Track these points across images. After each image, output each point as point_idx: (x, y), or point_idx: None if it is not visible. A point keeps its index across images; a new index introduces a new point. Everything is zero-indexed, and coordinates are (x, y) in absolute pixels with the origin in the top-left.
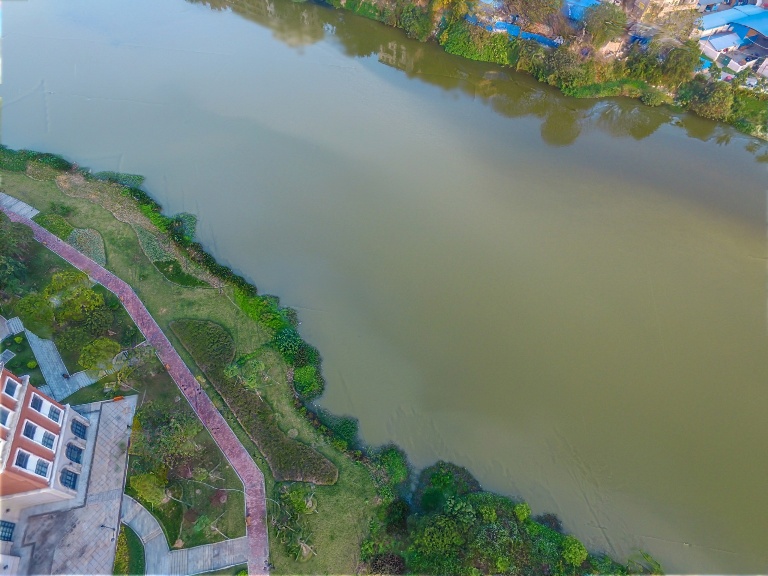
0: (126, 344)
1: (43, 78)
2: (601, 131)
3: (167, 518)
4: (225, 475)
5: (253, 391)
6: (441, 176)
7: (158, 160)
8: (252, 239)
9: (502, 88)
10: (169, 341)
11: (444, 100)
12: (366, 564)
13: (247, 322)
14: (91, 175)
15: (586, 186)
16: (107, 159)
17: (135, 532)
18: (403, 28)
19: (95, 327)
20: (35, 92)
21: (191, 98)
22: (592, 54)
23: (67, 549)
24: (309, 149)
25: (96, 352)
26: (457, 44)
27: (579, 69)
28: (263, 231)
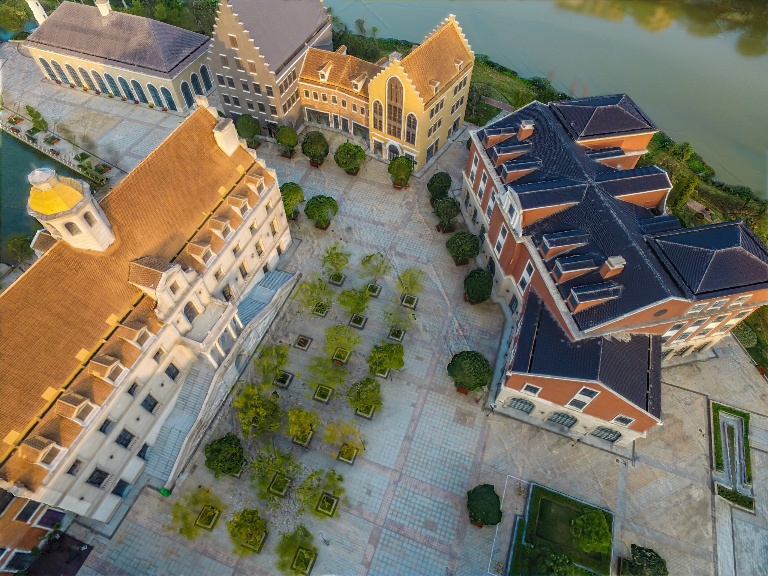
0: None
1: None
2: None
3: None
4: None
5: None
6: (716, 56)
7: (490, 45)
8: (600, 92)
9: None
10: None
11: (685, 9)
12: None
13: None
14: None
15: None
16: None
17: None
18: None
19: None
20: (355, 3)
21: (484, 7)
22: None
23: None
24: (602, 39)
25: None
26: None
27: None
28: (604, 88)
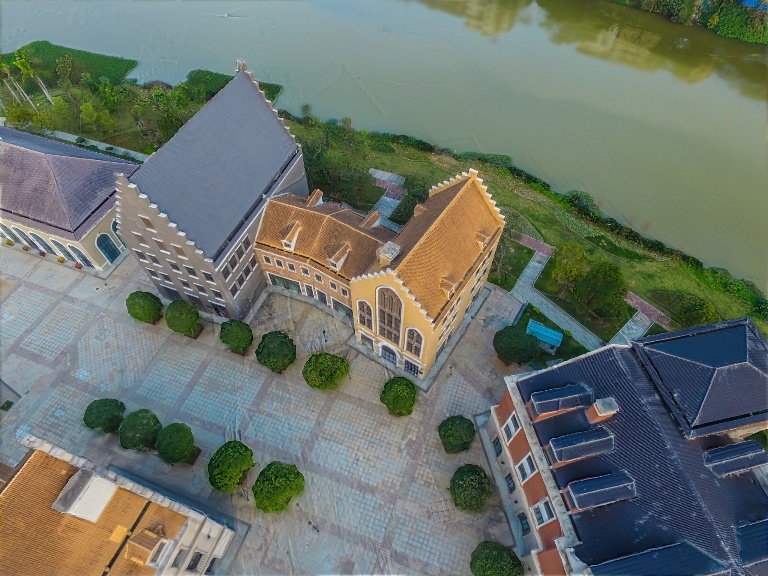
0: None
1: (342, 64)
2: None
3: None
4: None
5: None
6: None
7: (512, 141)
8: (660, 215)
9: None
10: (661, 311)
11: (750, 81)
12: None
13: (715, 293)
14: (458, 156)
15: None
16: (461, 140)
17: None
18: (660, 12)
19: None
20: (343, 77)
21: (502, 81)
22: None
23: None
24: (652, 129)
25: (712, 315)
26: (732, 27)
27: None
28: (664, 207)
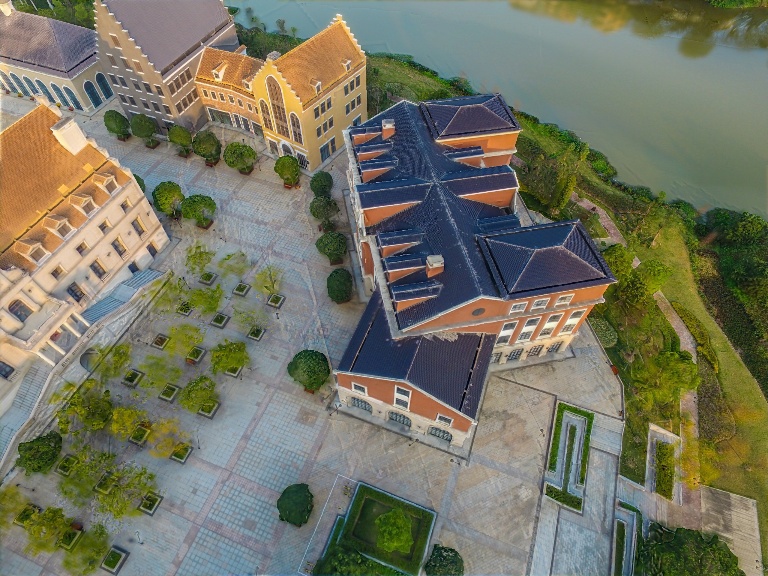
0: None
1: None
2: (729, 45)
3: None
4: None
5: None
6: (641, 56)
7: (416, 46)
8: (517, 92)
9: None
10: None
11: (619, 9)
12: (694, 252)
13: (543, 137)
14: (371, 54)
15: (755, 63)
16: (376, 45)
17: None
18: None
19: None
20: (289, 3)
21: (418, 7)
22: None
23: None
24: (530, 39)
25: None
26: None
27: None
28: (523, 88)
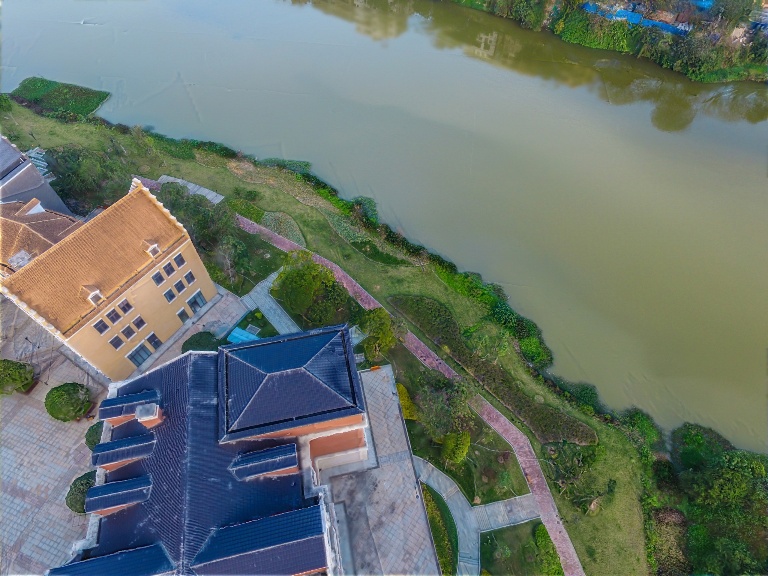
0: (355, 319)
1: (178, 71)
2: (712, 116)
3: (460, 477)
4: (493, 438)
5: (490, 361)
6: (598, 158)
7: (318, 147)
8: (435, 220)
9: (608, 76)
10: None
11: (576, 86)
12: (651, 517)
13: (458, 297)
14: (259, 162)
15: (741, 166)
16: (268, 147)
17: (435, 490)
18: (514, 18)
19: (338, 301)
20: (175, 84)
21: (330, 88)
22: (723, 39)
23: (377, 506)
24: (461, 134)
25: (379, 320)
26: (575, 33)
27: (711, 54)
28: (443, 212)
